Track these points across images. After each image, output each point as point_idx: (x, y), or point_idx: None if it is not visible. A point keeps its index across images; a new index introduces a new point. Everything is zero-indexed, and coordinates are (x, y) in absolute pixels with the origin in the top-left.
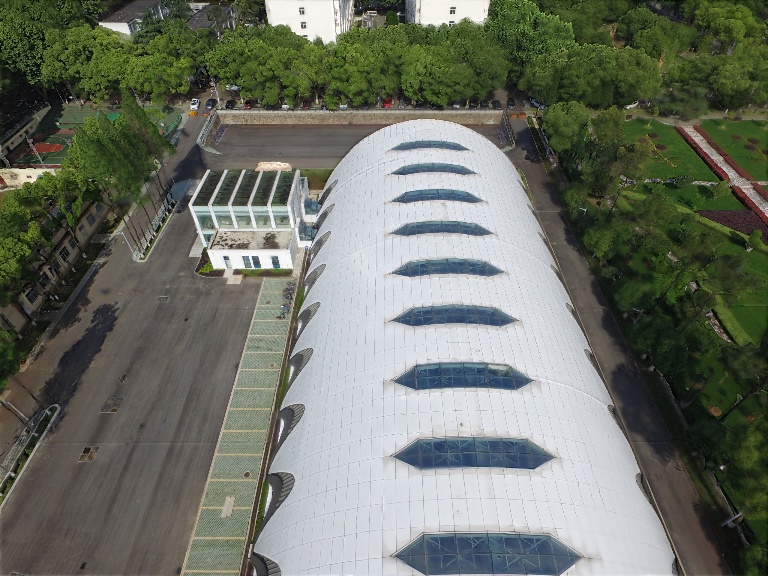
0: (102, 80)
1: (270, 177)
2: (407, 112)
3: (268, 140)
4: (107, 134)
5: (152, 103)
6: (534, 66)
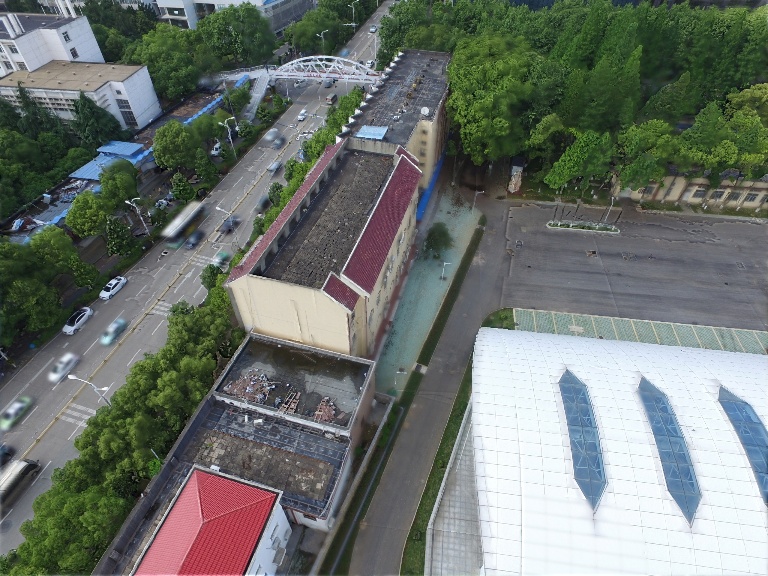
0: None
1: None
2: None
3: None
4: None
5: None
6: None
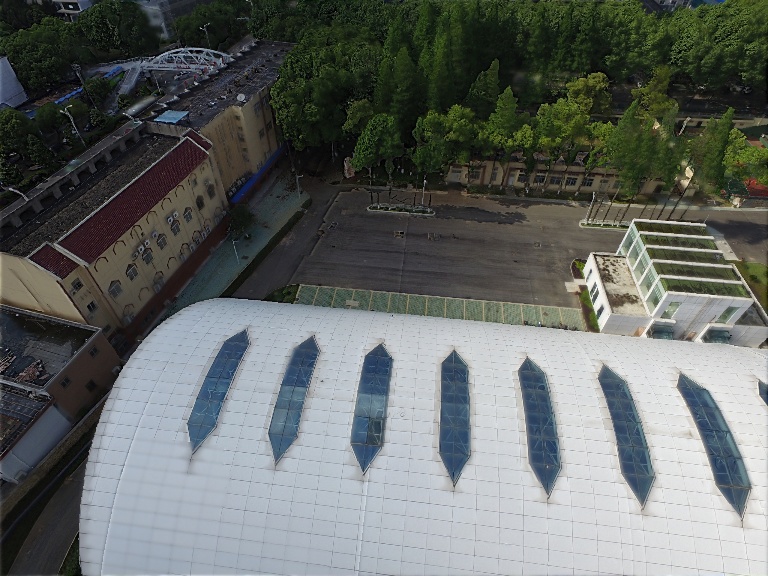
0: None
1: (721, 275)
2: None
3: None
4: (662, 127)
5: None
6: None
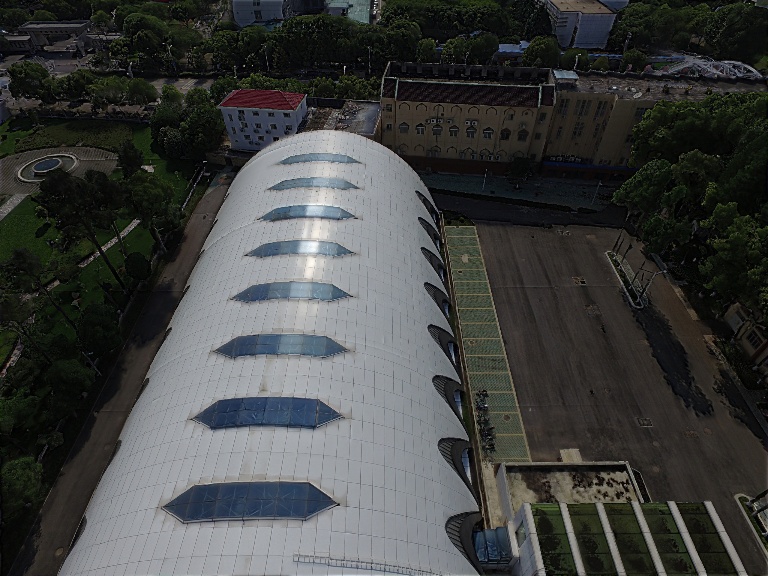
0: None
1: None
2: None
3: None
4: None
5: None
6: None
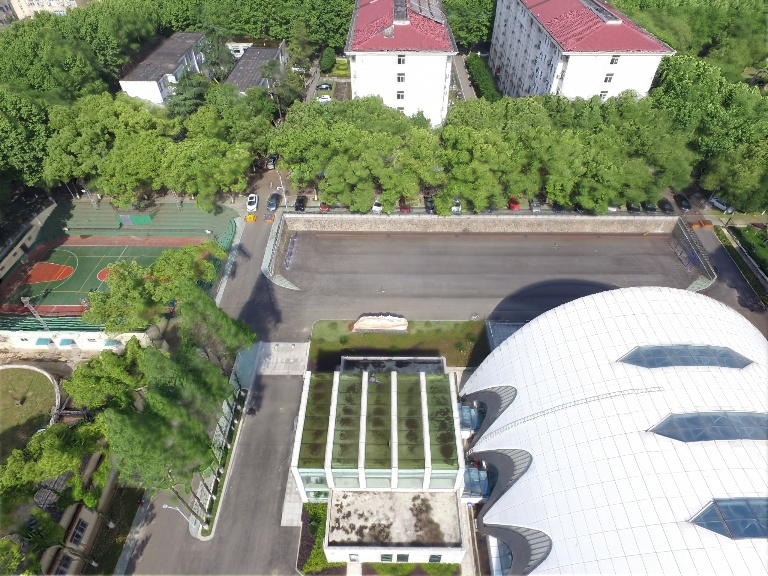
0: (128, 180)
1: (410, 389)
2: (545, 217)
3: (358, 261)
4: (159, 378)
5: (194, 200)
6: (731, 160)
